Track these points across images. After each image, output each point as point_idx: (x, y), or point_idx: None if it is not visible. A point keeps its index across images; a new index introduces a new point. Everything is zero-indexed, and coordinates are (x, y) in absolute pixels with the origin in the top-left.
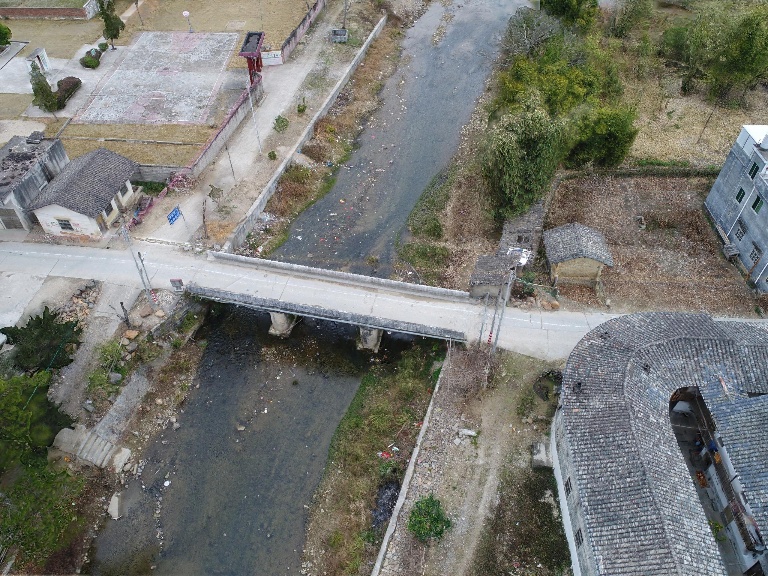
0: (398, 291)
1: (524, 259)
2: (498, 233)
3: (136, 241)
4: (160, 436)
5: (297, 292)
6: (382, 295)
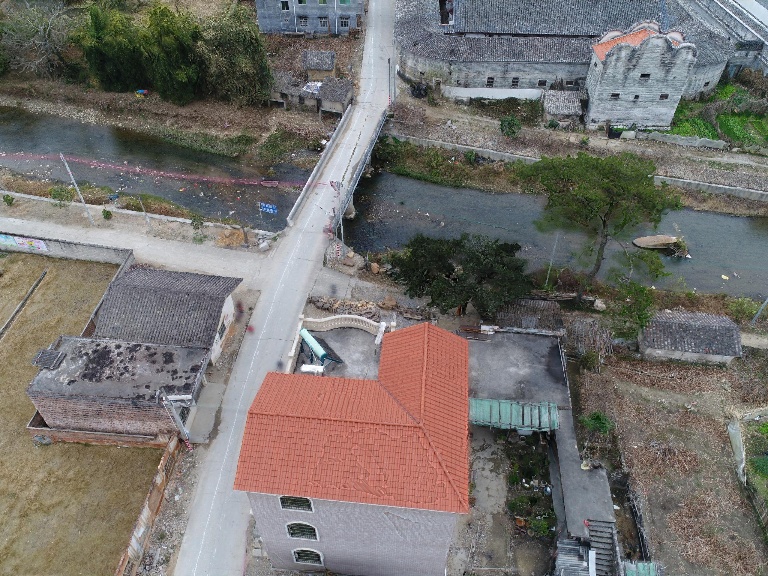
0: (341, 134)
1: (319, 83)
2: (263, 109)
3: (243, 289)
4: None
5: (338, 177)
6: (343, 141)
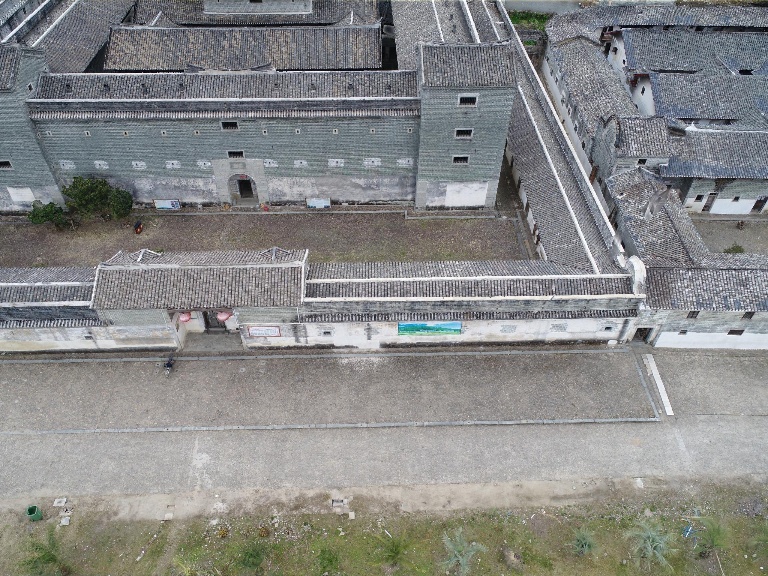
0: None
1: None
2: None
3: None
4: (701, 3)
5: None
6: None
